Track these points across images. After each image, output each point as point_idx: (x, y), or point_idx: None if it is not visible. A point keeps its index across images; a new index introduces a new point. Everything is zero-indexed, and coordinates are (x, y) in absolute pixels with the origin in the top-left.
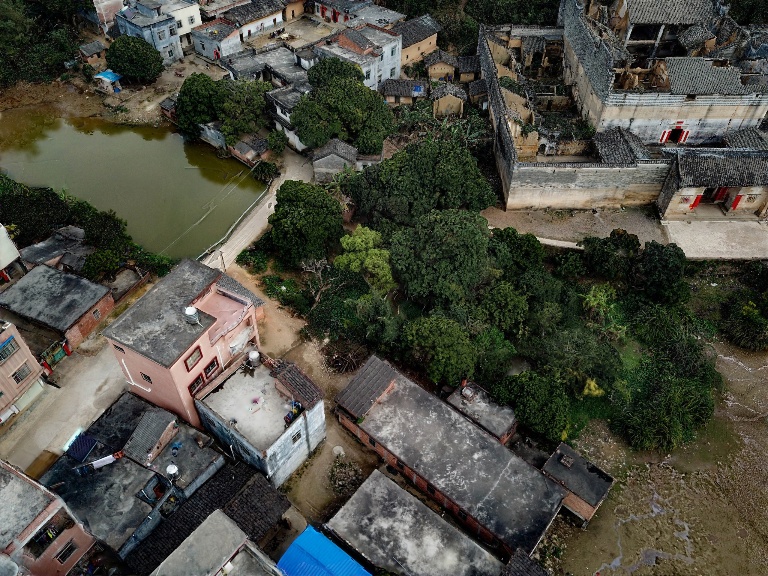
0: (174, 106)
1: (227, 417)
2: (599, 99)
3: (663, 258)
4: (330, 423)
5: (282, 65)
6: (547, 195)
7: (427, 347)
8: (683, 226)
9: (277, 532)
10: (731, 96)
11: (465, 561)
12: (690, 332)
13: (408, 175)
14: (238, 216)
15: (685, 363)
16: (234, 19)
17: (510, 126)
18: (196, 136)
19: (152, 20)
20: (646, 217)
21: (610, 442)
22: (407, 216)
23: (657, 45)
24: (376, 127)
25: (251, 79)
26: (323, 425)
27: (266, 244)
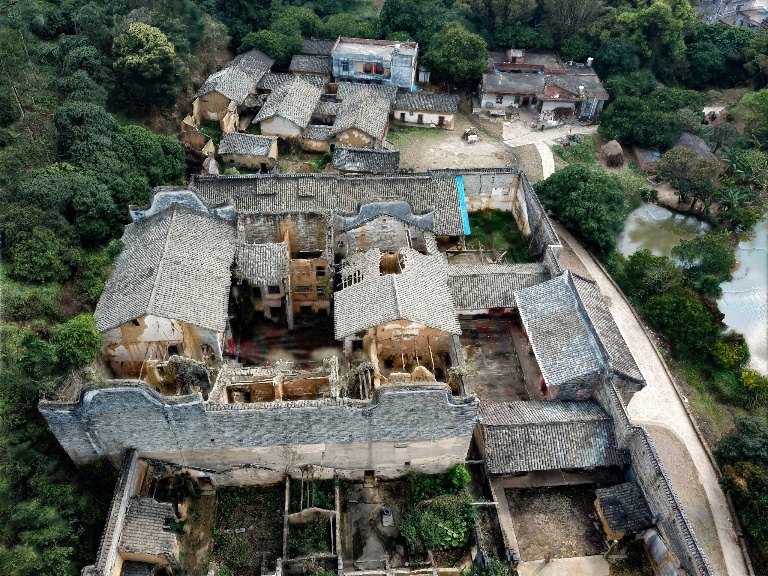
0: None
1: None
2: (444, 439)
3: None
4: None
5: None
6: None
7: None
8: None
9: None
10: None
11: None
12: None
13: None
14: None
15: None
16: None
17: None
18: None
19: None
20: None
21: None
22: None
23: None
24: None
25: None
26: None
27: None
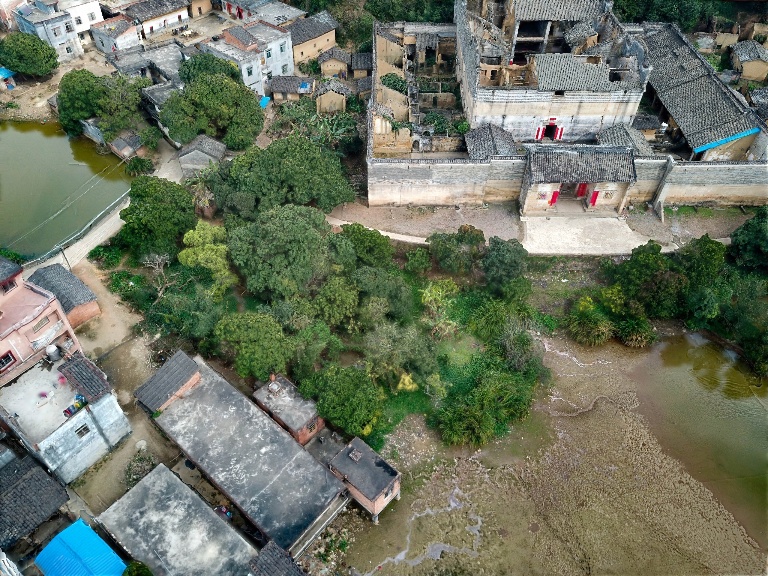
0: (56, 102)
1: (12, 411)
2: (471, 95)
3: (500, 254)
4: (140, 418)
5: (168, 61)
6: (406, 191)
7: (232, 342)
8: (541, 222)
9: (60, 526)
10: (599, 93)
11: (225, 554)
12: None
13: (256, 171)
14: (98, 212)
15: (510, 358)
16: (135, 16)
17: (380, 122)
18: (79, 132)
19: (48, 16)
20: (507, 213)
21: (423, 437)
22: (255, 212)
23: (546, 42)
24: (243, 123)
25: (136, 75)
26: (123, 419)
27: (122, 240)
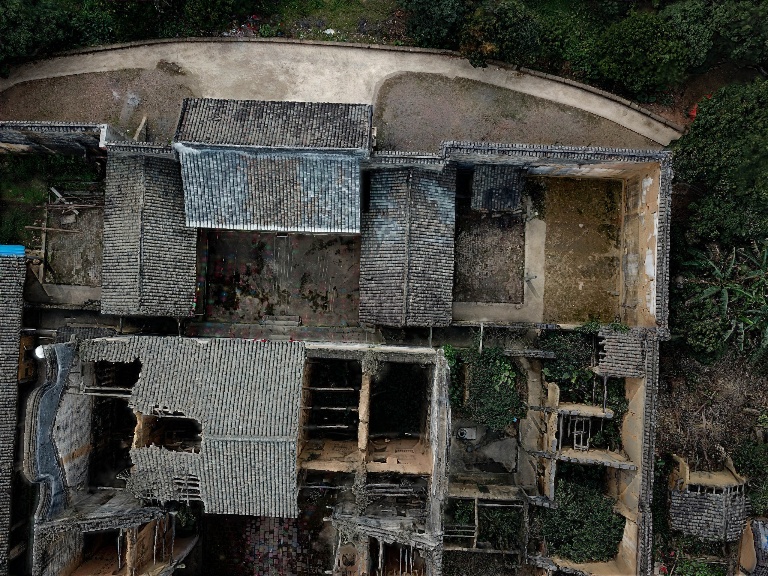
0: None
1: None
2: None
3: None
4: None
5: None
6: None
7: None
8: None
9: None
10: None
11: None
12: None
13: None
14: None
15: None
16: None
17: None
18: None
19: None
20: None
21: None
22: None
23: None
24: None
25: None
26: None
27: None
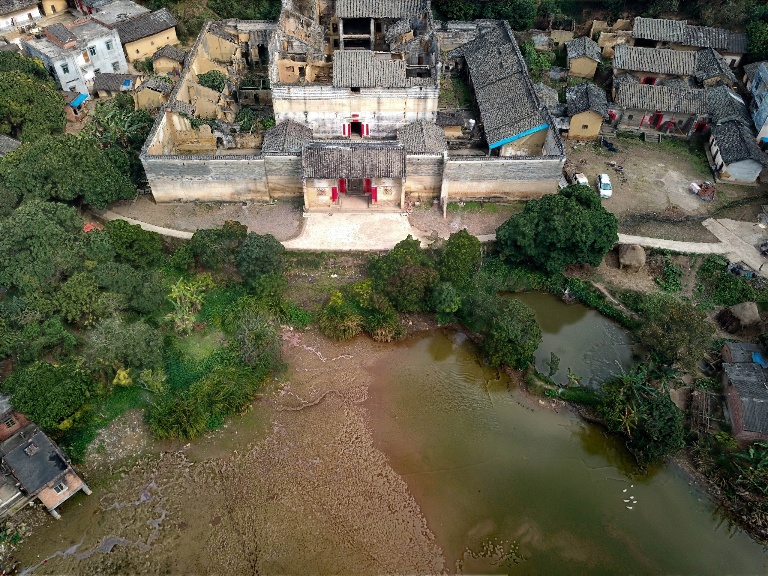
0: None
1: None
2: None
3: (249, 249)
4: None
5: None
6: (189, 187)
7: None
8: (323, 218)
9: None
10: (395, 89)
11: None
12: (283, 323)
13: (21, 167)
14: None
15: (242, 353)
16: None
17: (177, 119)
18: None
19: None
20: (293, 209)
21: (136, 432)
22: None
23: (373, 39)
24: (37, 120)
25: None
26: None
27: None
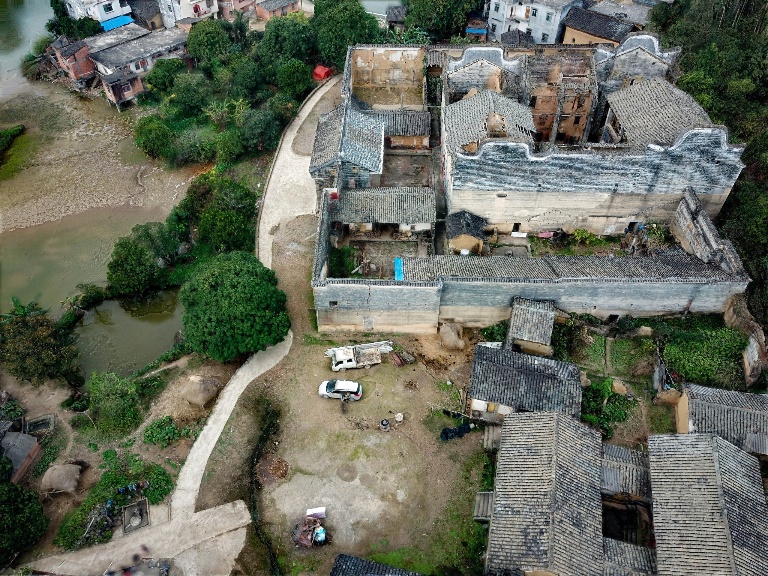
0: None
1: None
2: None
3: None
4: None
5: None
6: None
7: None
8: None
9: None
10: None
11: None
12: None
13: None
14: None
15: None
16: None
17: None
18: None
19: None
20: None
21: None
22: None
23: None
24: None
25: None
26: None
27: None
